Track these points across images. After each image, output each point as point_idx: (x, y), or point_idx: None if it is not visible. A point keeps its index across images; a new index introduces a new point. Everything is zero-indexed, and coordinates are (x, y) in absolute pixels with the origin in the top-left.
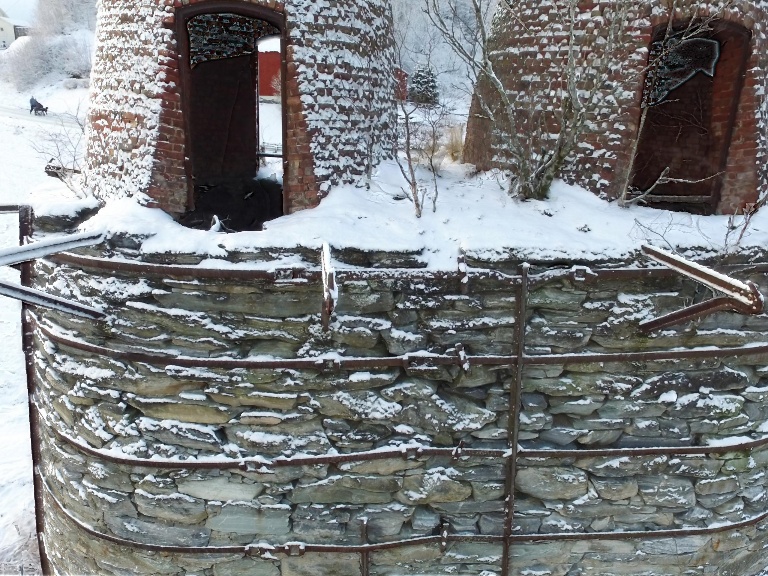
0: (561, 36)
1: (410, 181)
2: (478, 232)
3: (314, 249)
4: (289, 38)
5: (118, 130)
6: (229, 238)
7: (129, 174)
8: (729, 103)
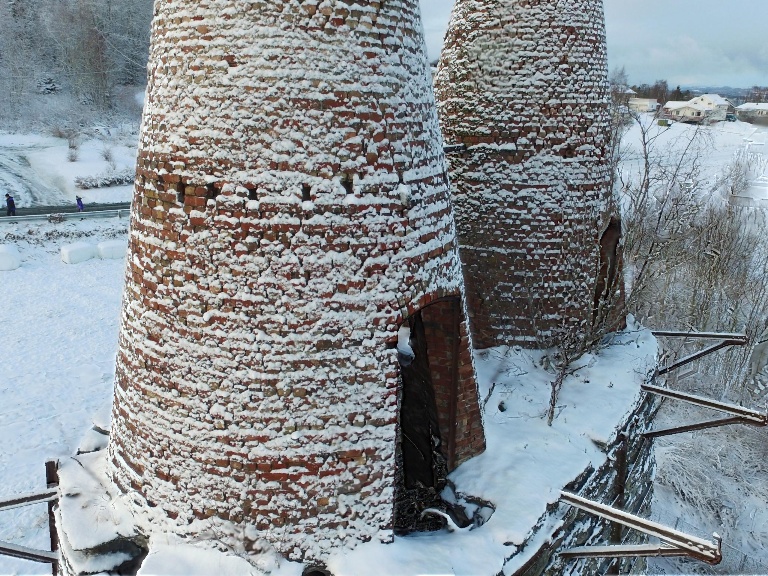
0: (545, 243)
1: (552, 403)
2: (590, 421)
3: (557, 501)
4: (463, 316)
5: (333, 474)
6: (512, 533)
7: (360, 517)
8: (607, 264)
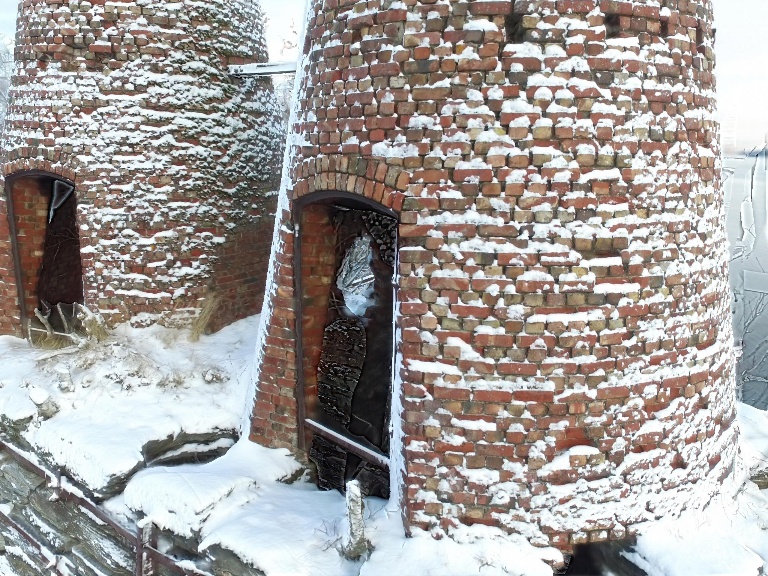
0: None
1: None
2: None
3: None
4: None
5: None
6: None
7: None
8: None
